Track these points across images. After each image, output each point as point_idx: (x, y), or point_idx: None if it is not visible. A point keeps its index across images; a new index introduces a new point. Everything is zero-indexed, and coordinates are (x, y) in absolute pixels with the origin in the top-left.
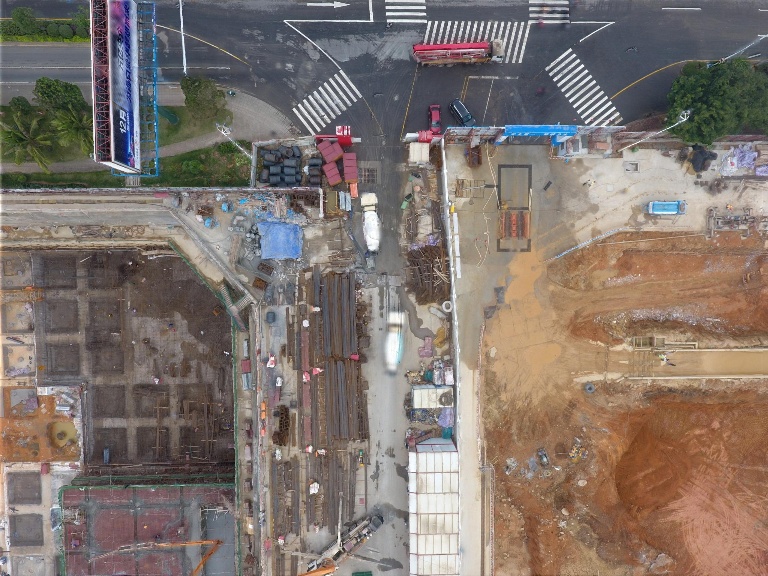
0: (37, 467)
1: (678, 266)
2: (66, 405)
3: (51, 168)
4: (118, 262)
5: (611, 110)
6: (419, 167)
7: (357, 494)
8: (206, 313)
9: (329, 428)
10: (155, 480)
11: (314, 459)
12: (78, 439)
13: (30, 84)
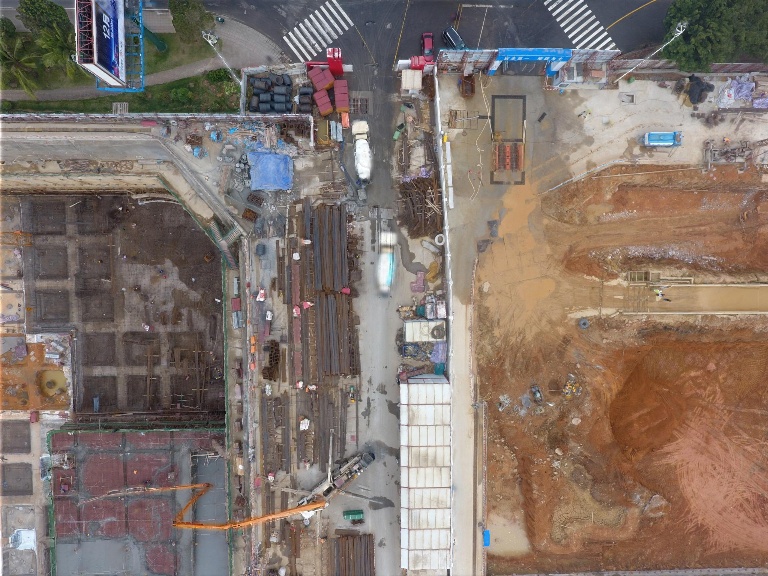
0: (26, 416)
1: (674, 203)
2: (55, 353)
3: (37, 96)
4: (108, 207)
5: (607, 41)
6: (411, 97)
7: (348, 431)
8: (197, 260)
9: (320, 364)
10: (145, 426)
11: (305, 395)
12: (68, 388)
13: (15, 9)
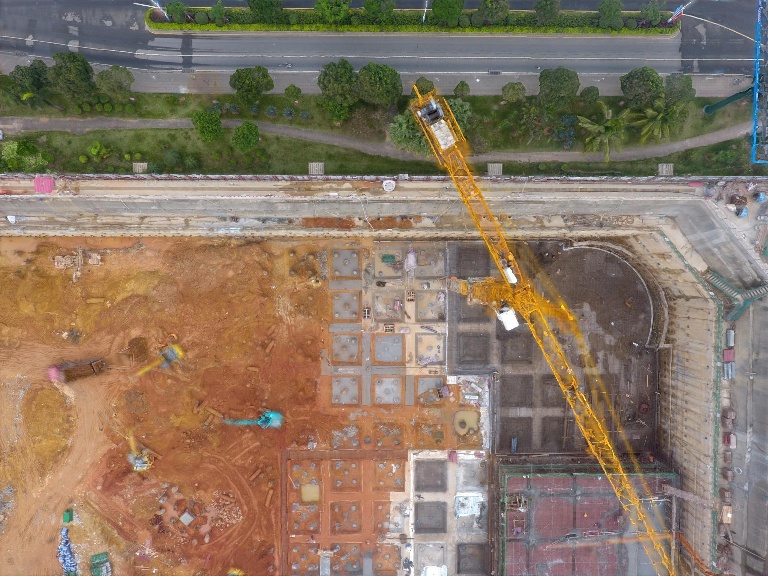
0: (443, 455)
1: None
2: (472, 394)
3: (588, 157)
4: (533, 253)
5: None
6: None
7: None
8: (617, 304)
9: None
10: (585, 469)
11: None
12: (481, 428)
13: None
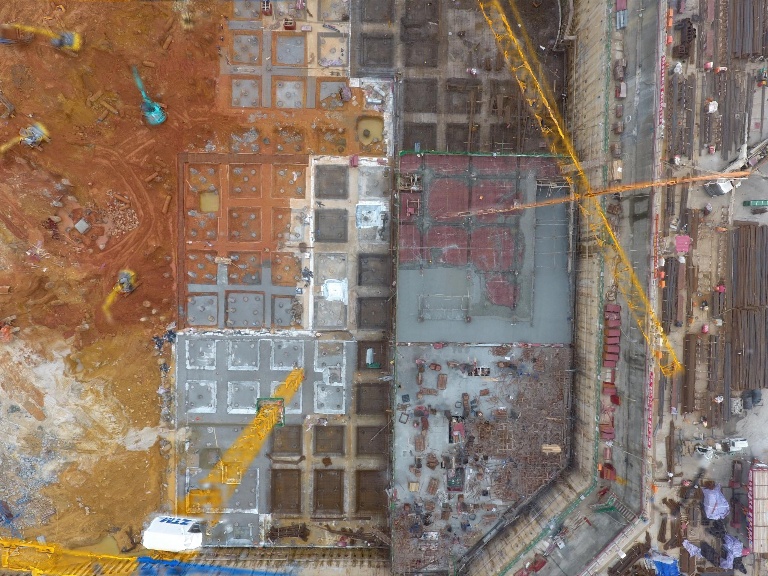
0: (345, 161)
1: None
2: None
3: None
4: None
5: None
6: None
7: (753, 118)
8: (524, 5)
9: (729, 46)
10: None
11: (711, 79)
12: (385, 136)
13: None
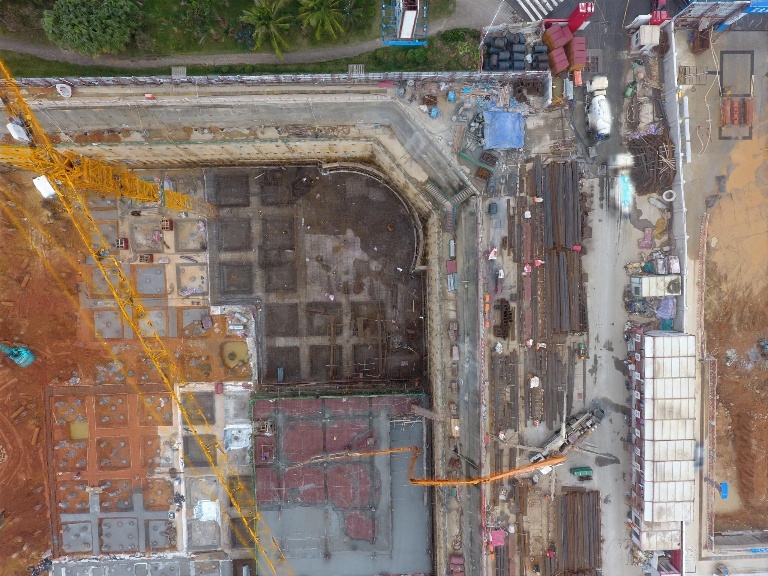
0: (210, 387)
1: None
2: (238, 325)
3: (275, 59)
4: (292, 178)
5: None
6: (642, 54)
7: (575, 388)
8: (380, 229)
9: (548, 321)
10: (339, 393)
11: (532, 354)
12: (250, 359)
13: None
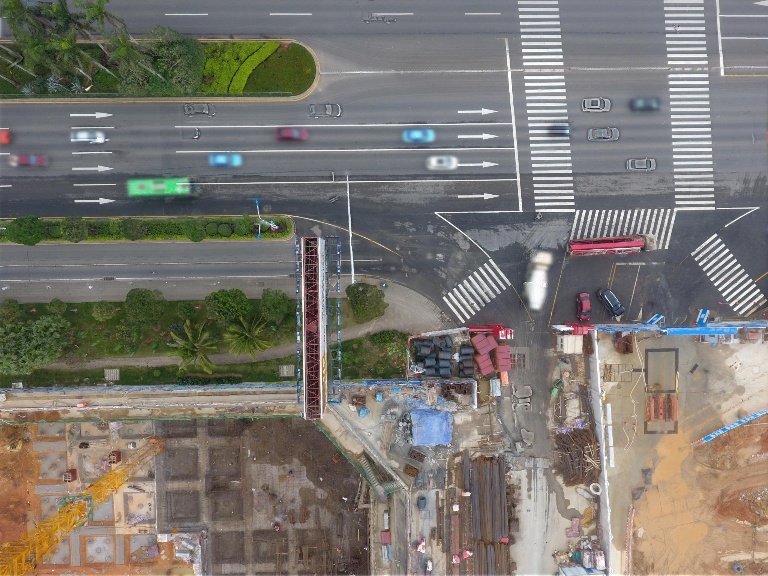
0: None
1: None
2: (185, 551)
3: None
4: None
5: (755, 292)
6: None
7: None
8: (325, 460)
9: None
10: None
11: None
12: None
13: (187, 279)
